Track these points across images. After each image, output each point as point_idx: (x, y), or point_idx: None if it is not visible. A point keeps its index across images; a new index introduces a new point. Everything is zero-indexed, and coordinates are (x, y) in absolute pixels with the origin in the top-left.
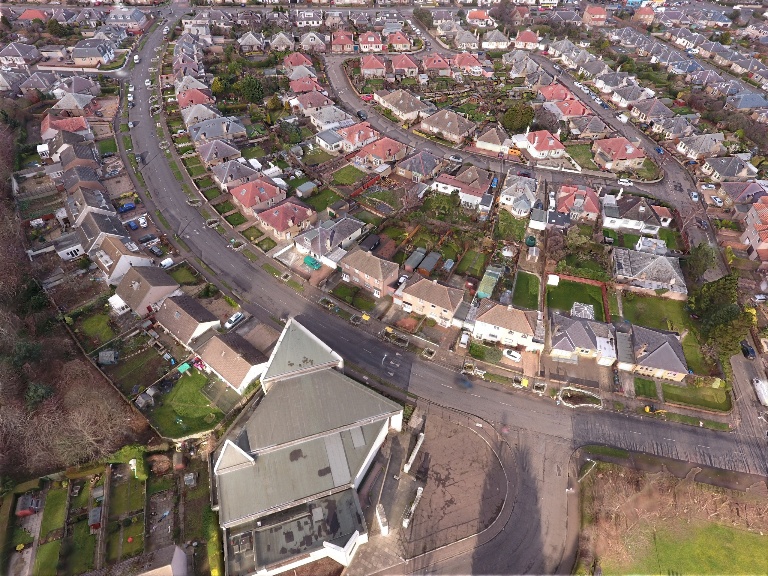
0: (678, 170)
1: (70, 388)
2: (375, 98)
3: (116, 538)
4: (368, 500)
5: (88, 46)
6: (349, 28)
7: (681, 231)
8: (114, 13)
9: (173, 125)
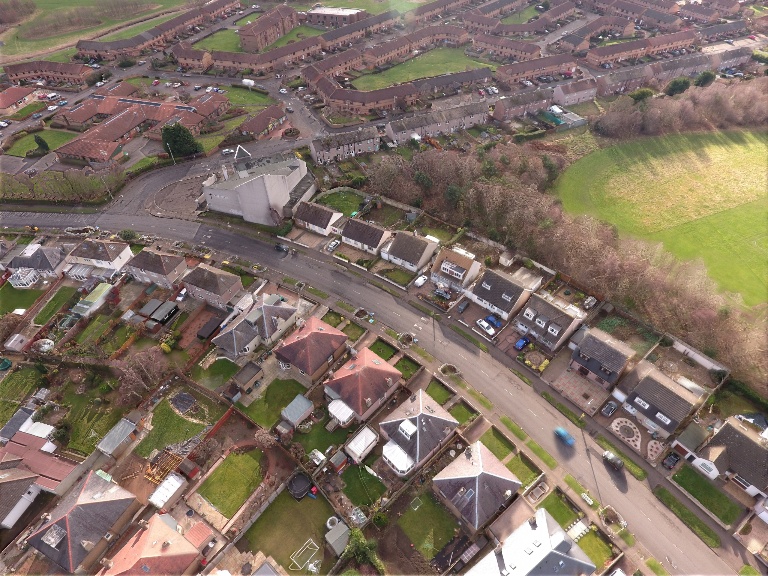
0: None
1: (405, 180)
2: None
3: None
4: None
5: None
6: None
7: None
8: None
9: None
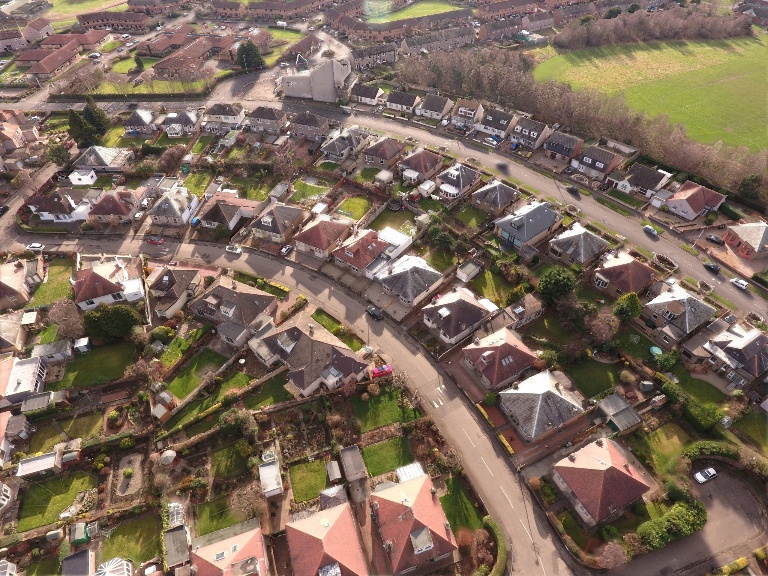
0: None
1: None
2: None
3: None
4: None
5: None
6: None
7: None
8: None
9: None
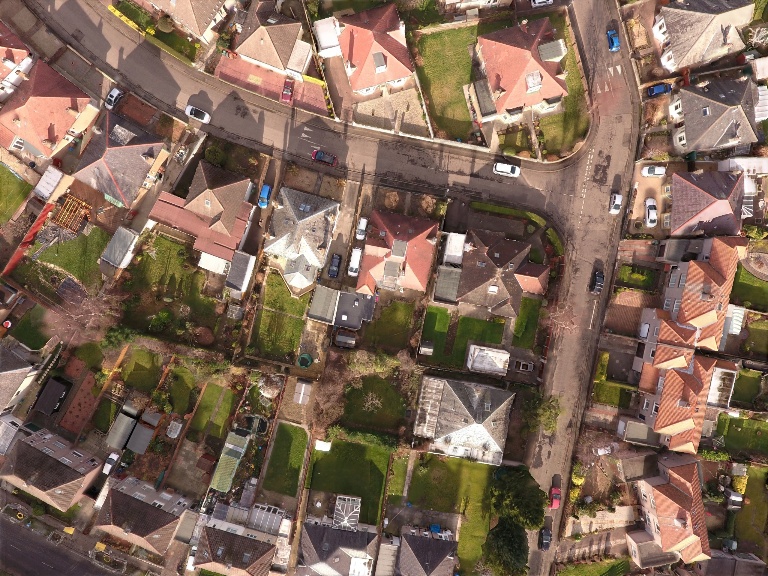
0: (624, 110)
1: None
2: None
3: None
4: None
5: None
6: None
7: (550, 316)
8: None
9: None
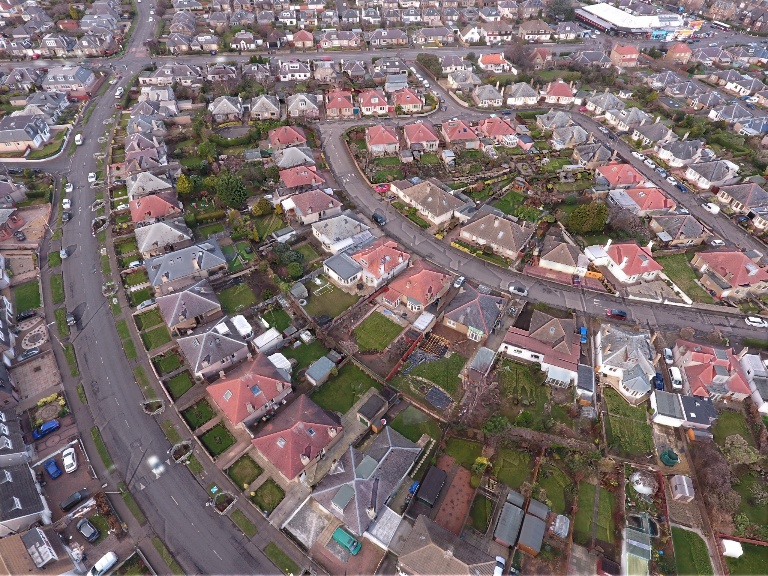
0: None
1: None
2: (392, 189)
3: None
4: None
5: (12, 127)
6: (344, 83)
7: None
8: (53, 73)
9: (124, 250)
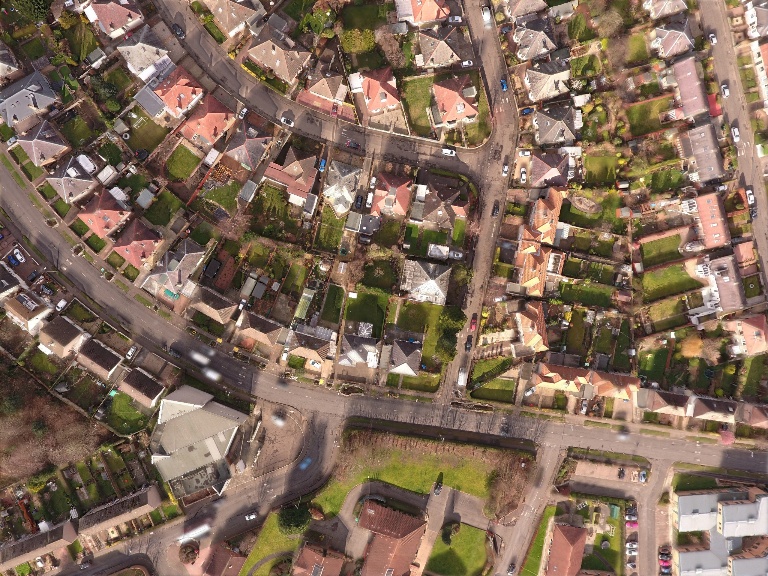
0: (510, 121)
1: (54, 426)
2: None
3: (119, 480)
4: (235, 455)
5: None
6: None
7: None
8: None
9: None
